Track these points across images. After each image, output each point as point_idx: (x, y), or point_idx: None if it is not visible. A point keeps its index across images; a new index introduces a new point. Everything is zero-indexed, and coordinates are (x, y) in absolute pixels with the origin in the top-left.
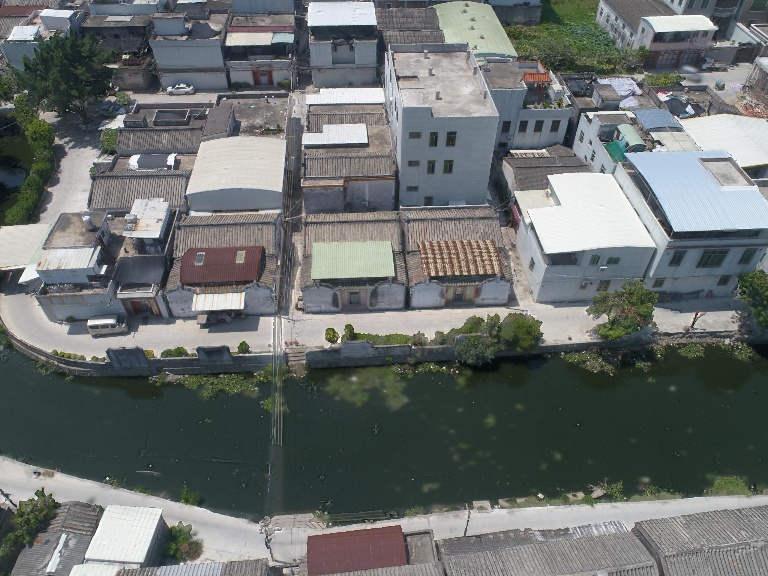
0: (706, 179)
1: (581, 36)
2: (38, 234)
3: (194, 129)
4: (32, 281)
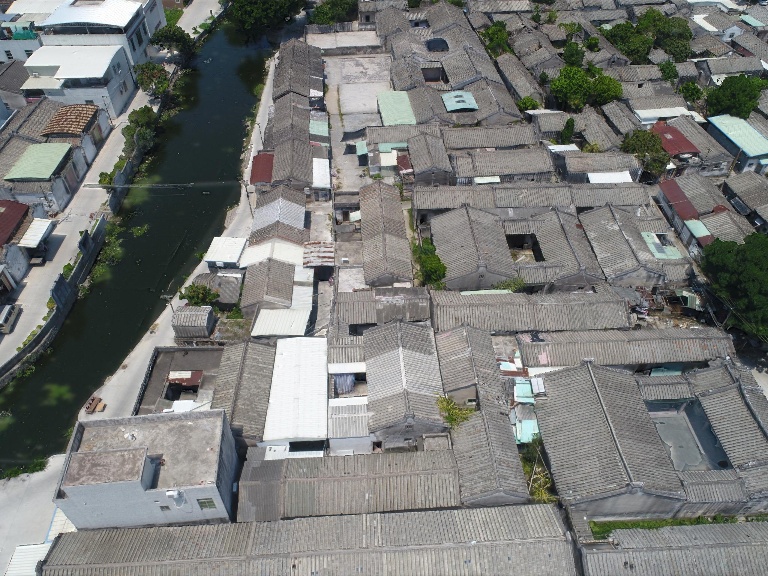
0: (90, 8)
1: None
2: None
3: None
4: None
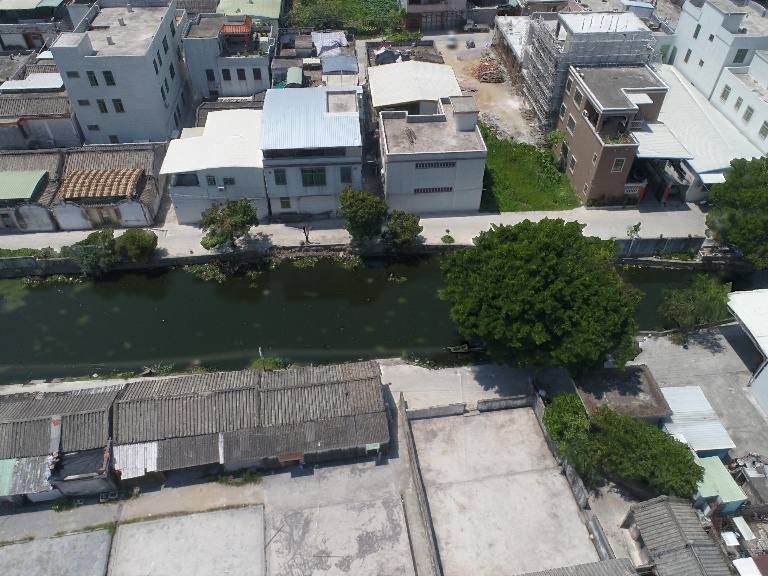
0: (318, 108)
1: (370, 3)
2: None
3: None
4: None
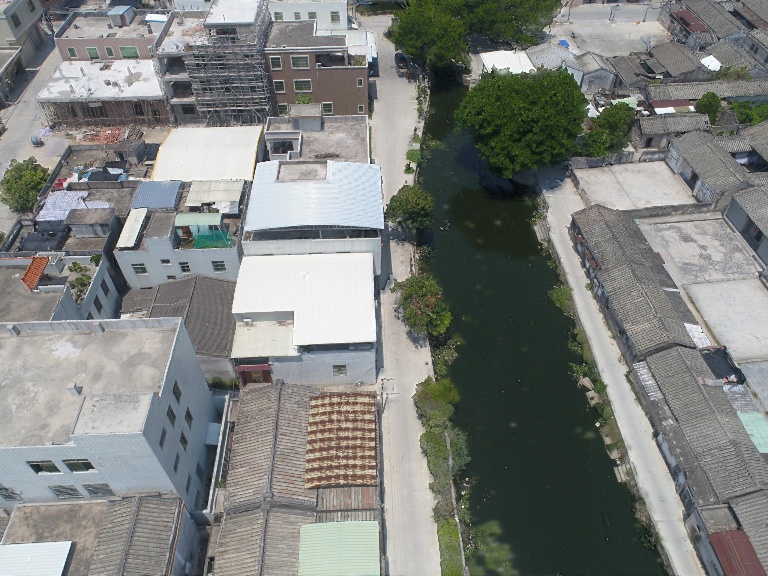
0: (312, 186)
1: None
2: None
3: None
4: None
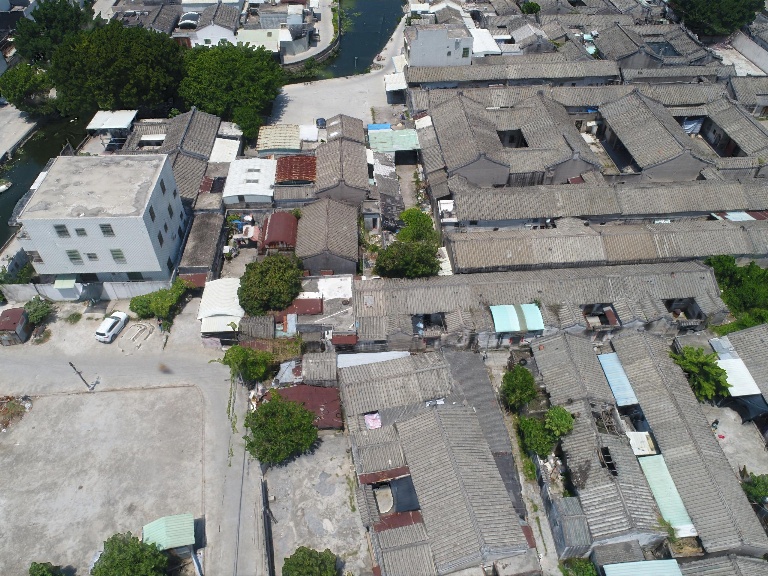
0: None
1: None
2: (250, 43)
3: (162, 7)
4: (293, 36)
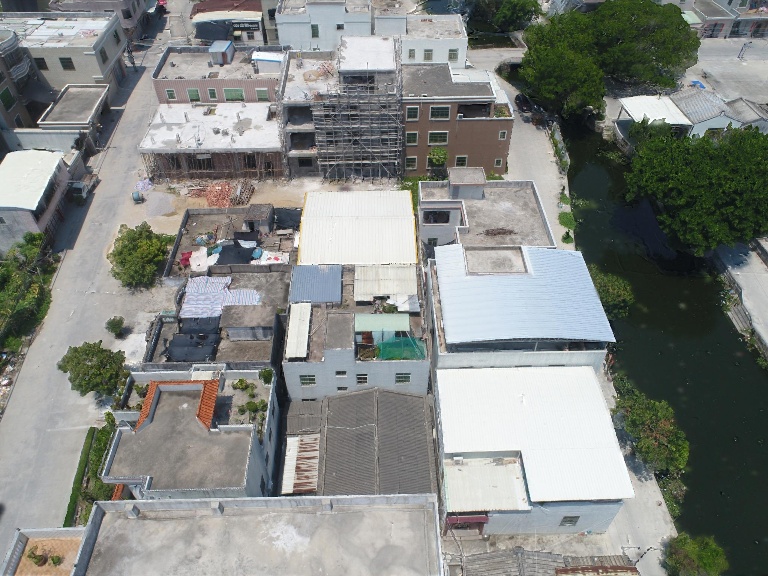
0: (513, 282)
1: None
2: None
3: None
4: None
